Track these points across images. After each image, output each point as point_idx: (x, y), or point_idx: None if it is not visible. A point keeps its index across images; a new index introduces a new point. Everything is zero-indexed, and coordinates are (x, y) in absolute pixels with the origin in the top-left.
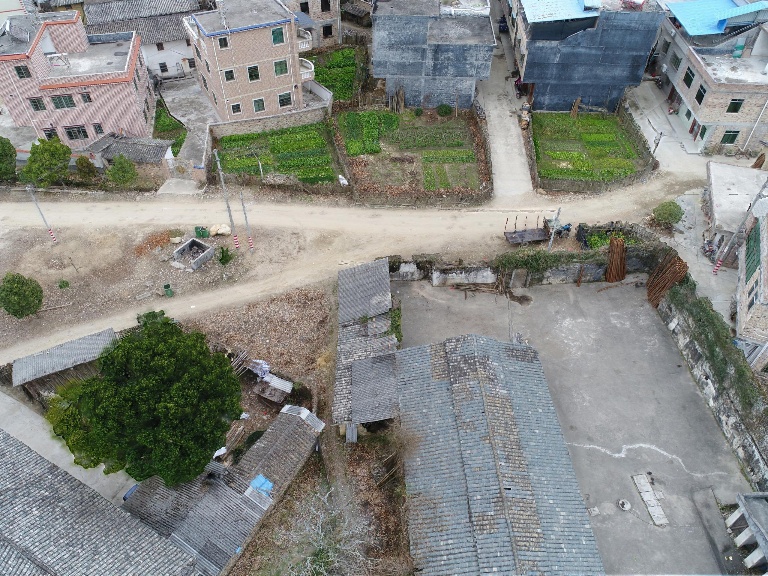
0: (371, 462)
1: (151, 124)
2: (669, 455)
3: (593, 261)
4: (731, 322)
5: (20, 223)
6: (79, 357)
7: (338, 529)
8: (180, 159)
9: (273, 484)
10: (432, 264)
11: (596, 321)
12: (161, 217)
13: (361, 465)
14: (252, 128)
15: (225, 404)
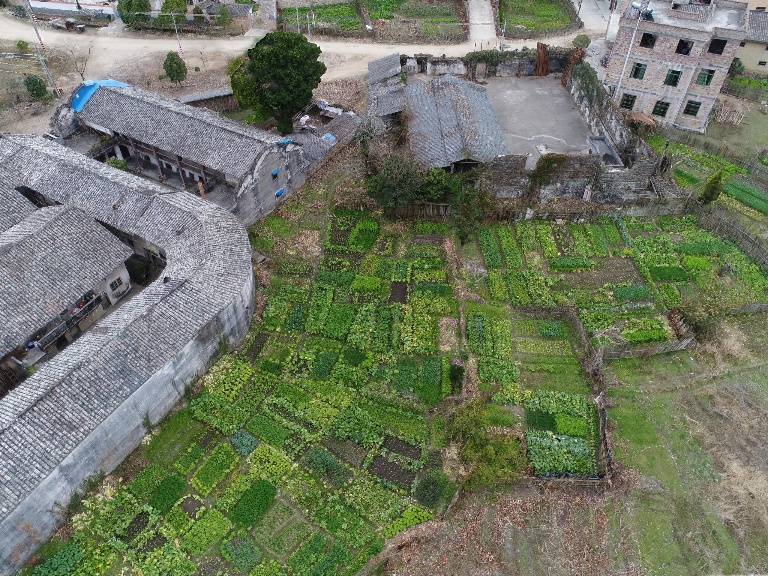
0: (389, 141)
1: (233, 2)
2: (558, 139)
3: (527, 58)
4: (610, 93)
5: (157, 49)
6: (216, 94)
7: (372, 148)
8: (260, 13)
9: (336, 138)
10: (426, 60)
11: (527, 91)
12: (249, 47)
13: (383, 142)
14: (304, 3)
15: (318, 62)
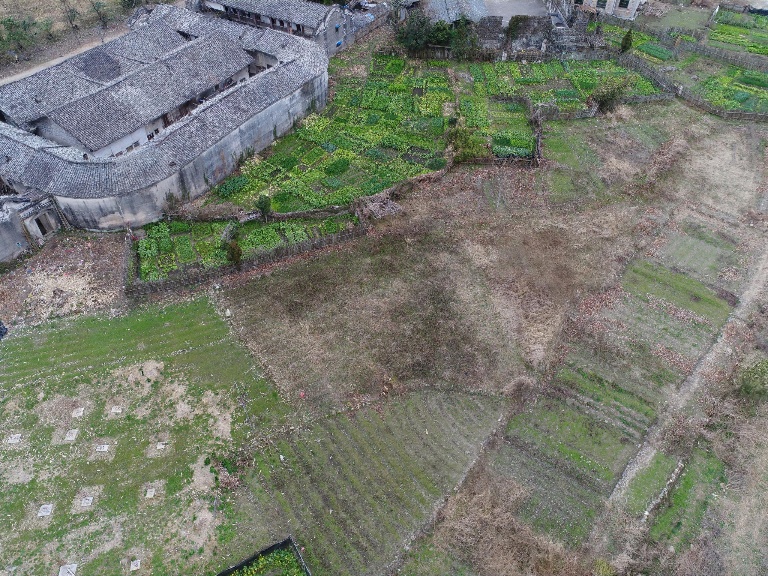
0: None
1: None
2: None
3: None
4: None
5: None
6: None
7: None
8: None
9: (374, 17)
10: None
11: None
12: None
13: None
14: None
15: None
